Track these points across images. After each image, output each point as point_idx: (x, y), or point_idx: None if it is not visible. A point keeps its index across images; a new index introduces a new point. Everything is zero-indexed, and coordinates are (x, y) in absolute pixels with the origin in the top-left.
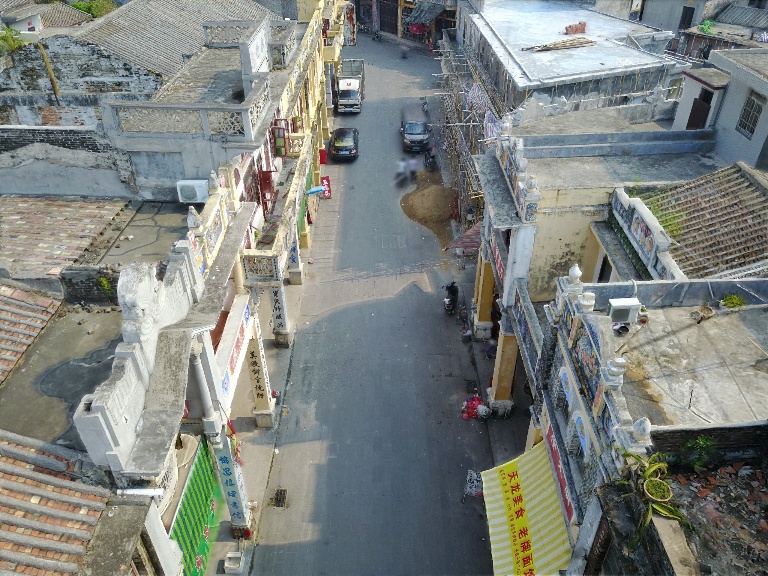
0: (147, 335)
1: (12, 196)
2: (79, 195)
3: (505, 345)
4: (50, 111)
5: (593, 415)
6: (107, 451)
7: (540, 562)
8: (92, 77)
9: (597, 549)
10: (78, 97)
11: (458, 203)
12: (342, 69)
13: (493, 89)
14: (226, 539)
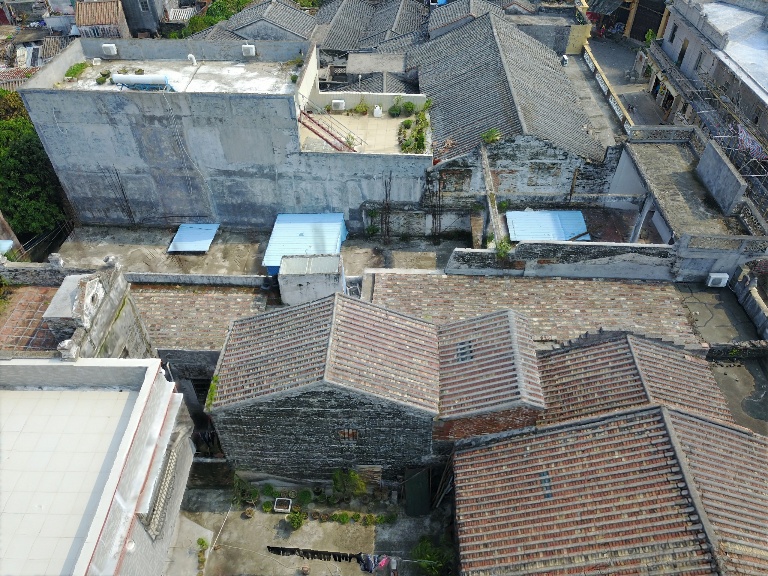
0: None
1: (600, 280)
2: (638, 279)
3: None
4: (495, 180)
5: None
6: None
7: None
8: (537, 160)
9: None
10: (586, 197)
11: None
12: None
13: (760, 134)
14: None
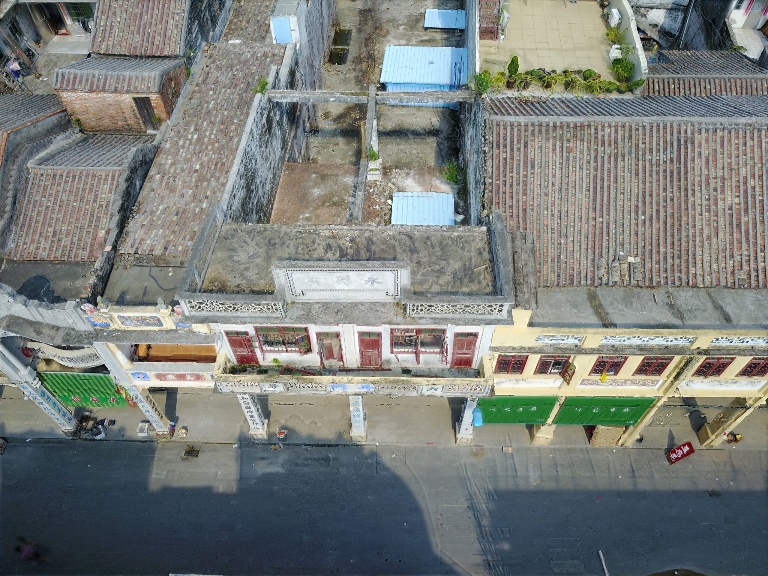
0: None
1: None
2: None
3: None
4: None
5: None
6: None
7: None
8: None
9: None
10: None
11: None
12: None
13: None
14: None
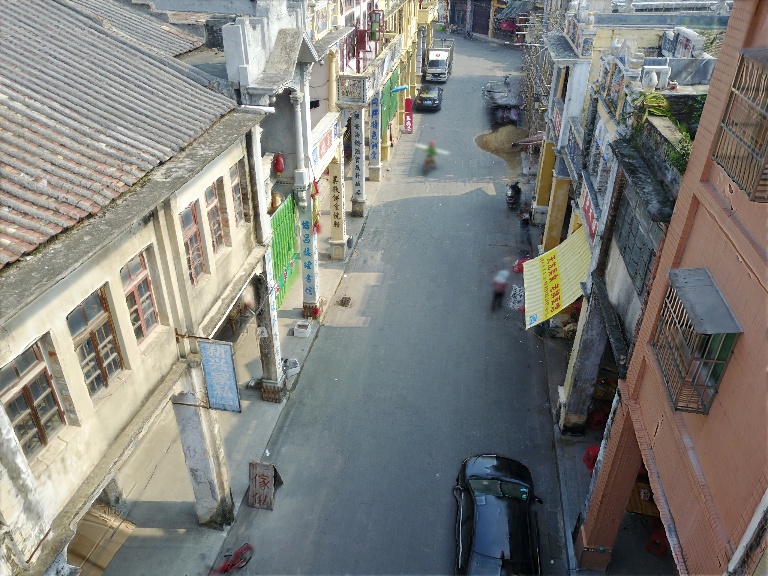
0: (272, 19)
1: None
2: None
3: (557, 190)
4: None
5: (616, 117)
6: (240, 65)
7: (566, 295)
8: None
9: (610, 216)
10: None
11: (529, 135)
12: (433, 47)
13: None
14: (297, 318)
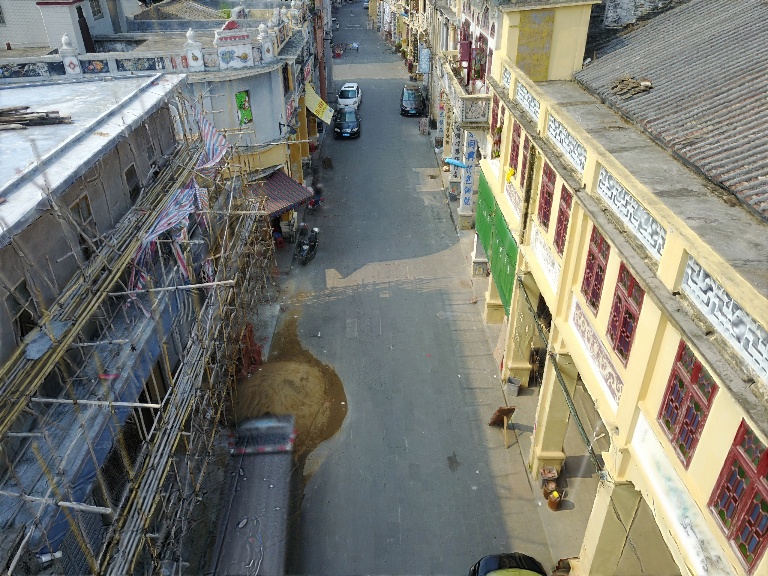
0: None
1: None
2: None
3: None
4: None
5: None
6: None
7: None
8: None
9: None
10: None
11: None
12: None
13: None
14: None
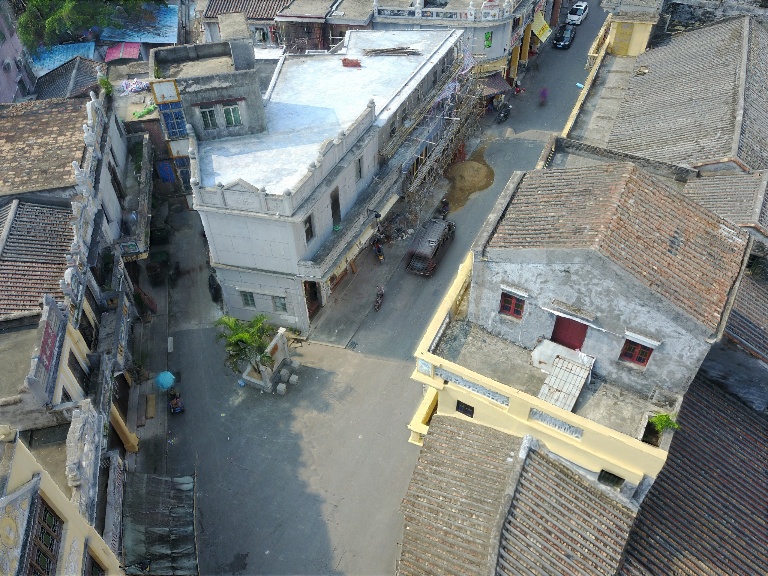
0: None
1: None
2: None
3: None
4: None
5: None
6: None
7: None
8: None
9: None
10: None
11: None
12: None
13: None
14: None
